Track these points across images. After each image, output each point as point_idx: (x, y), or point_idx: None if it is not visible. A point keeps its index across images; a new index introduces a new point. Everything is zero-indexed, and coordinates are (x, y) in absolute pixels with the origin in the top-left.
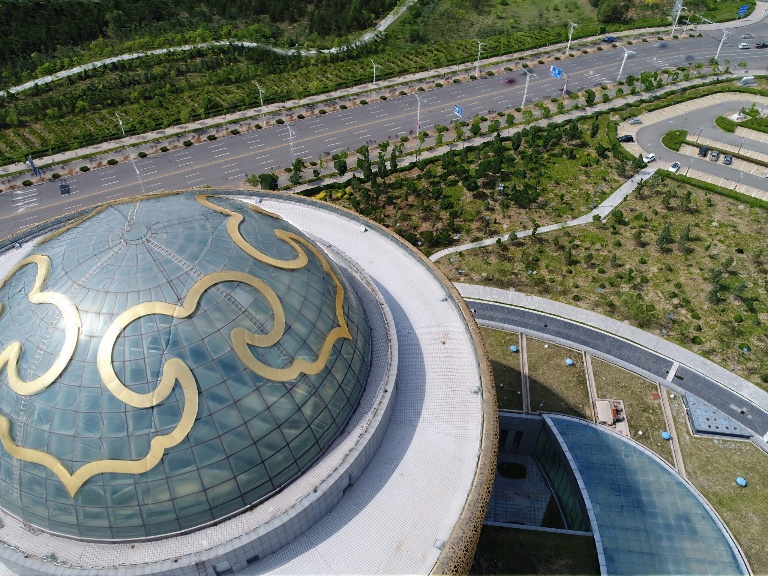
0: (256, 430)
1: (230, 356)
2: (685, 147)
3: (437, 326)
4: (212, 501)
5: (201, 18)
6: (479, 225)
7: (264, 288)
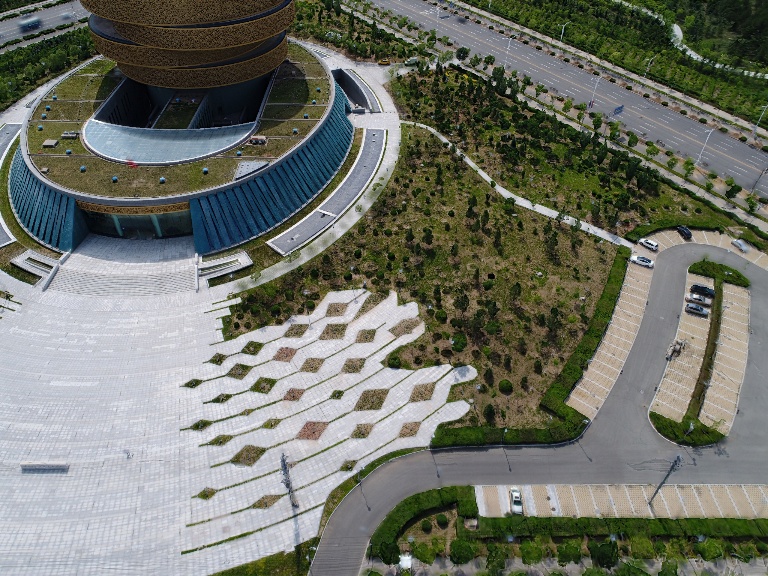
0: None
1: None
2: (706, 280)
3: None
4: None
5: (689, 1)
6: (471, 143)
7: None
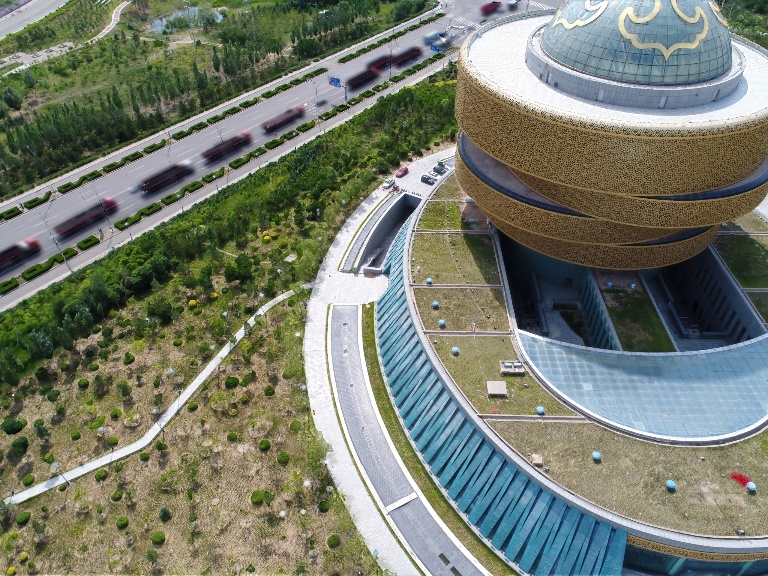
0: (599, 43)
1: (619, 13)
2: None
3: (722, 118)
4: (569, 56)
5: None
6: None
7: (657, 7)
